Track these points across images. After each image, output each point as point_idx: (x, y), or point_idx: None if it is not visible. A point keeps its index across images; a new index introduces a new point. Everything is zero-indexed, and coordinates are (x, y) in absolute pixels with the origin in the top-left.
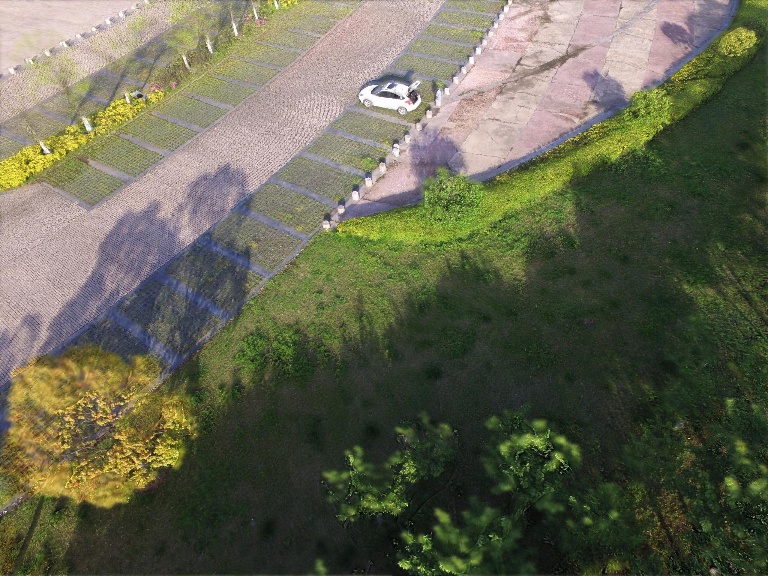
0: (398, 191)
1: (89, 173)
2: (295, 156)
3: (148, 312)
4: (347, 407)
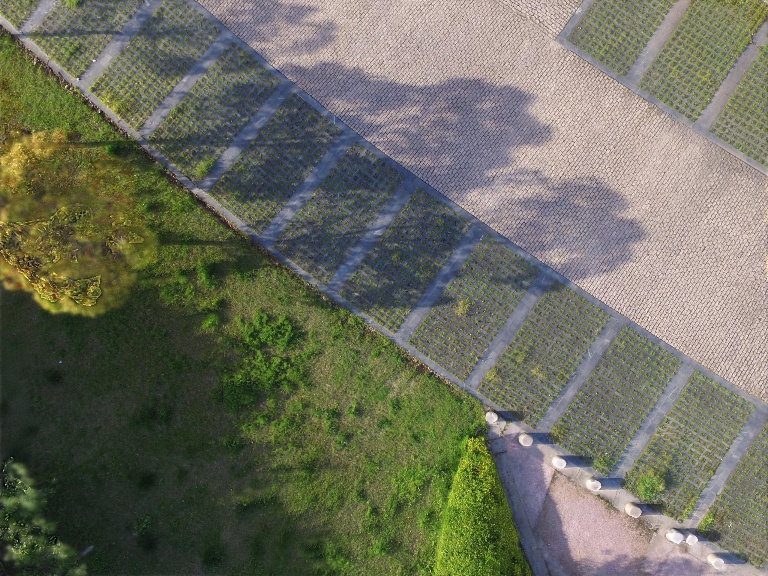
0: (571, 532)
1: (656, 5)
2: (682, 353)
3: (344, 185)
4: (174, 455)
